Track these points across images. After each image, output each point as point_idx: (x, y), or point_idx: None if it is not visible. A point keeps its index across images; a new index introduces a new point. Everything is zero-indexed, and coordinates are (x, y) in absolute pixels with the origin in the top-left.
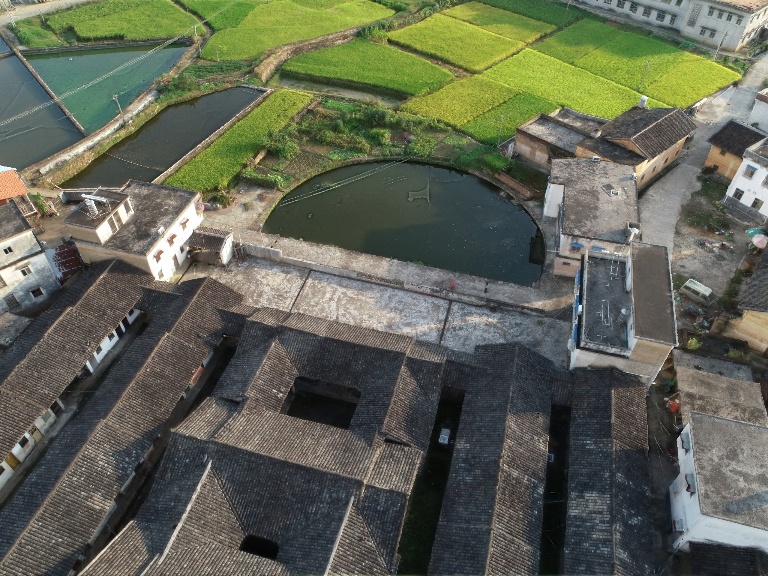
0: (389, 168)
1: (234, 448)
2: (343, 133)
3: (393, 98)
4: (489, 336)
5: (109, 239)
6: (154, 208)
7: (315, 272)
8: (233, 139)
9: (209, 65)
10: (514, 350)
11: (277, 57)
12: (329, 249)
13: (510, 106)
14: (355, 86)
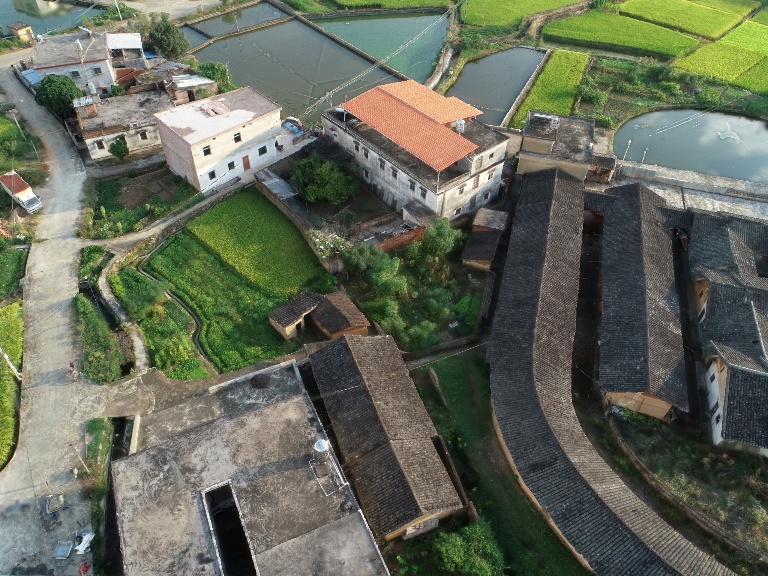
0: (686, 114)
1: (767, 292)
2: (636, 85)
3: (654, 59)
4: None
5: (551, 152)
6: (567, 131)
7: (687, 189)
8: (547, 88)
9: (480, 29)
10: None
11: (537, 23)
12: (686, 172)
13: (764, 66)
14: (616, 49)
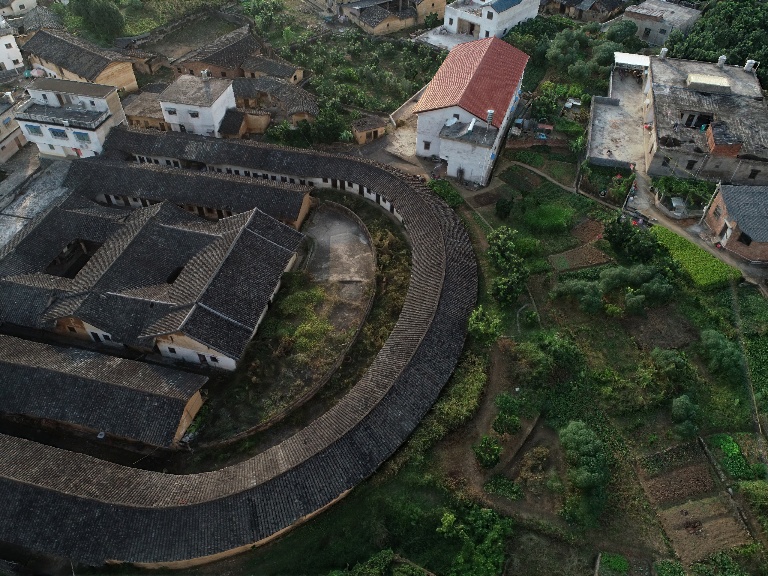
0: None
1: (103, 277)
2: None
3: None
4: (47, 197)
5: None
6: None
7: None
8: None
9: None
10: (78, 162)
11: None
12: None
13: None
14: None
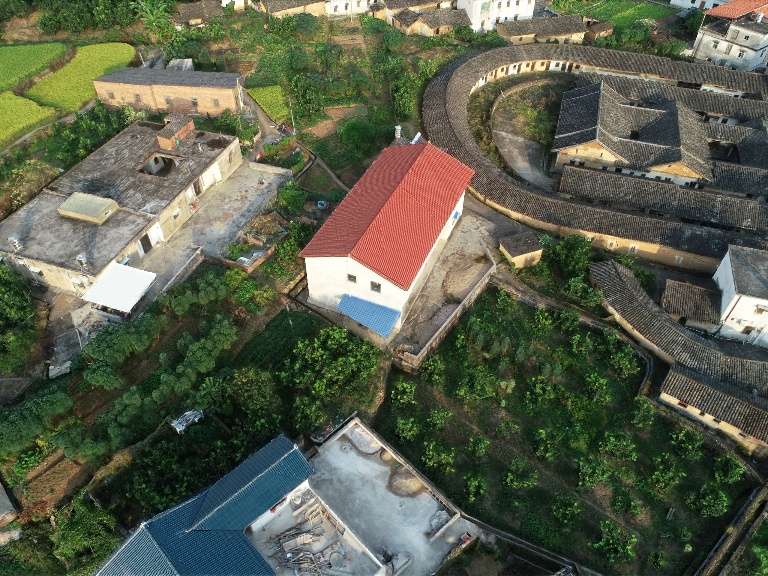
0: None
1: None
2: None
3: None
4: None
5: None
6: None
7: None
8: None
9: None
10: None
11: None
12: None
13: None
14: None
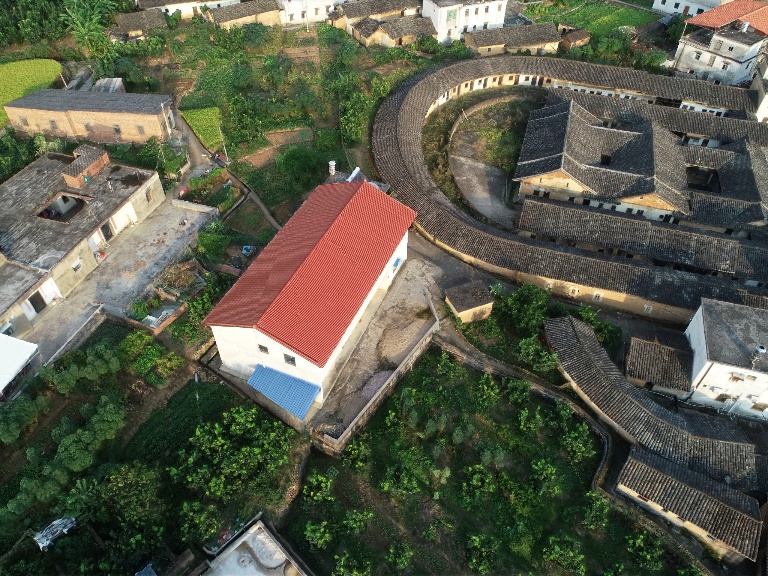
0: None
1: (652, 136)
2: None
3: None
4: None
5: None
6: None
7: None
8: None
9: None
10: None
11: None
12: None
13: None
14: None
